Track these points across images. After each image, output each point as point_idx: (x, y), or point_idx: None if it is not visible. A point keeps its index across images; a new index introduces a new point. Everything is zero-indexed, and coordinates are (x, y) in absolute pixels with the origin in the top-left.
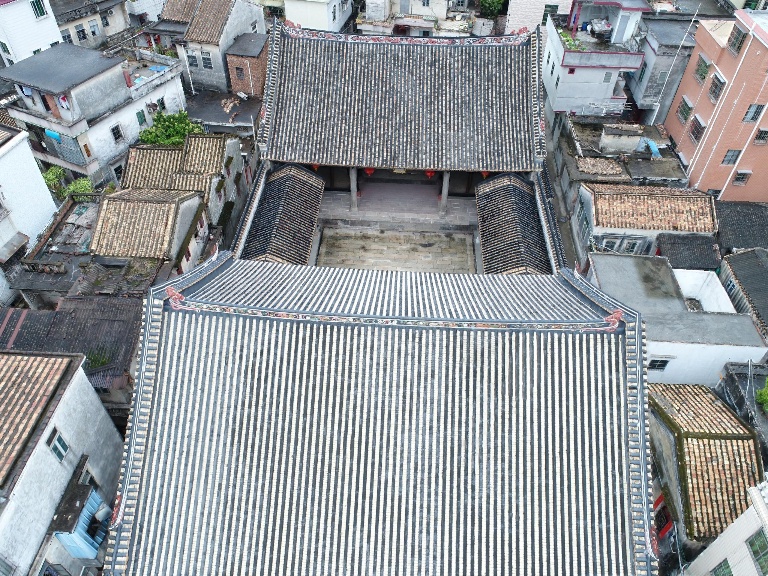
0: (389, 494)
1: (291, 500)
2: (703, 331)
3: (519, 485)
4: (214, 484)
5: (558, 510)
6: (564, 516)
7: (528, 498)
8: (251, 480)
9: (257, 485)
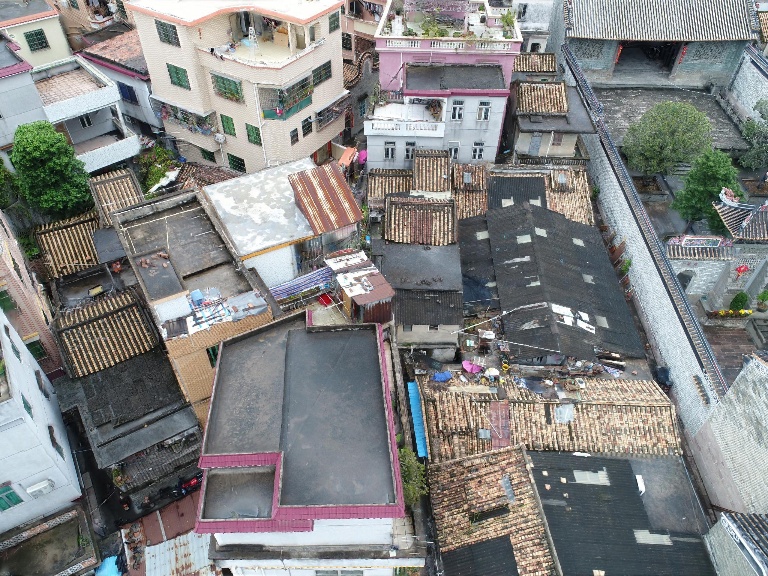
0: (659, 4)
1: (624, 7)
2: (758, 0)
3: (706, 0)
4: (595, 3)
5: (721, 7)
6: (723, 8)
7: (710, 4)
8: (608, 2)
9: (611, 3)
